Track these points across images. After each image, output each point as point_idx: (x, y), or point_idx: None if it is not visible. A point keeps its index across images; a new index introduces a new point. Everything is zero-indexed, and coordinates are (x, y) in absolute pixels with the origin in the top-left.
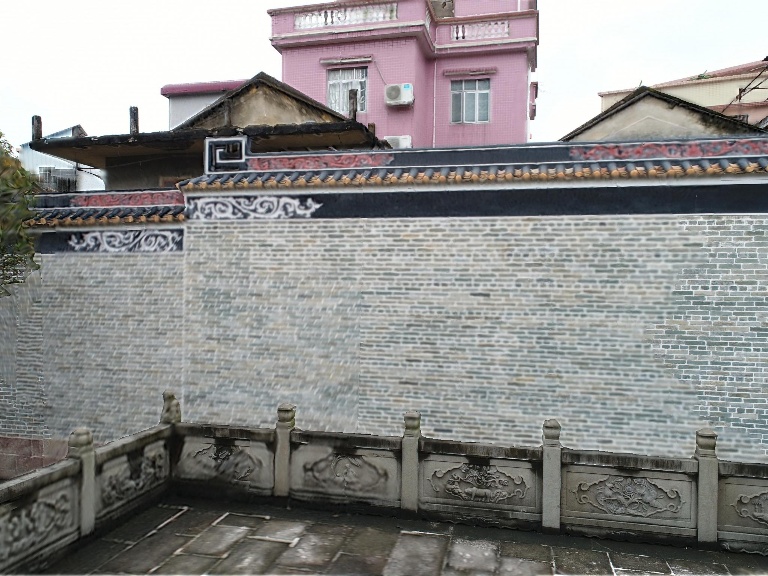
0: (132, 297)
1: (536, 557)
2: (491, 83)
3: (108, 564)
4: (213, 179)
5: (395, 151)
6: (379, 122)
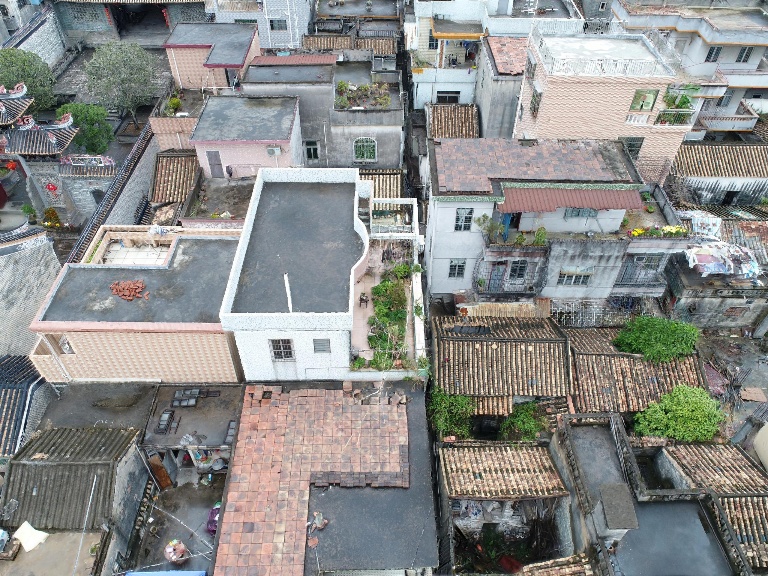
0: None
1: None
2: None
3: None
4: None
5: None
6: None
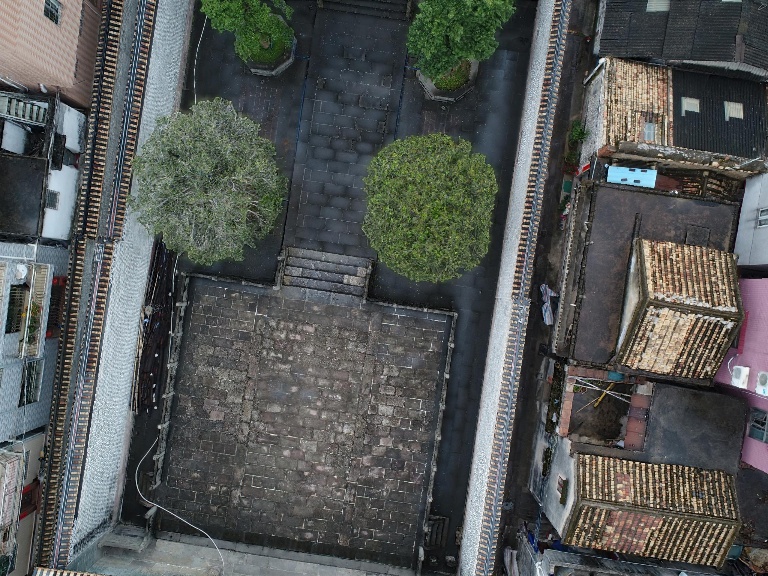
0: (510, 278)
1: (429, 398)
2: None
3: (417, 319)
4: (517, 309)
5: None
6: (763, 364)
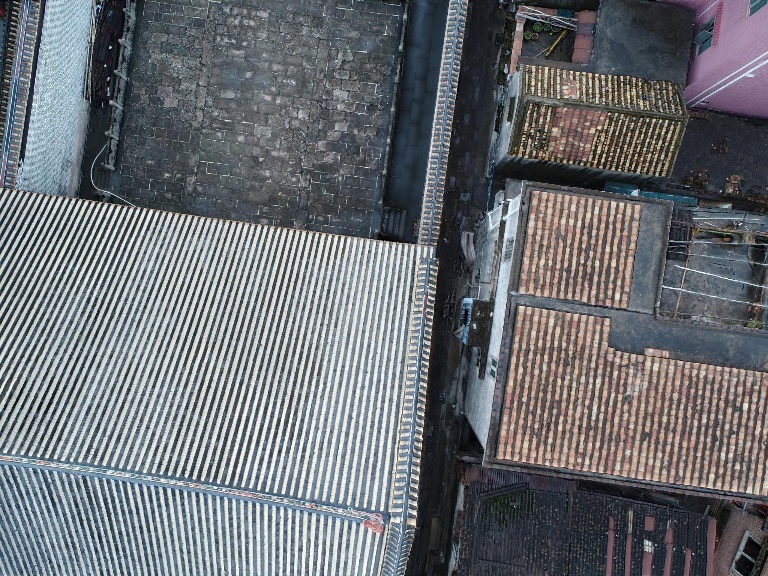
0: None
1: (384, 82)
2: (767, 3)
3: (372, 3)
4: None
5: (458, 2)
6: None
